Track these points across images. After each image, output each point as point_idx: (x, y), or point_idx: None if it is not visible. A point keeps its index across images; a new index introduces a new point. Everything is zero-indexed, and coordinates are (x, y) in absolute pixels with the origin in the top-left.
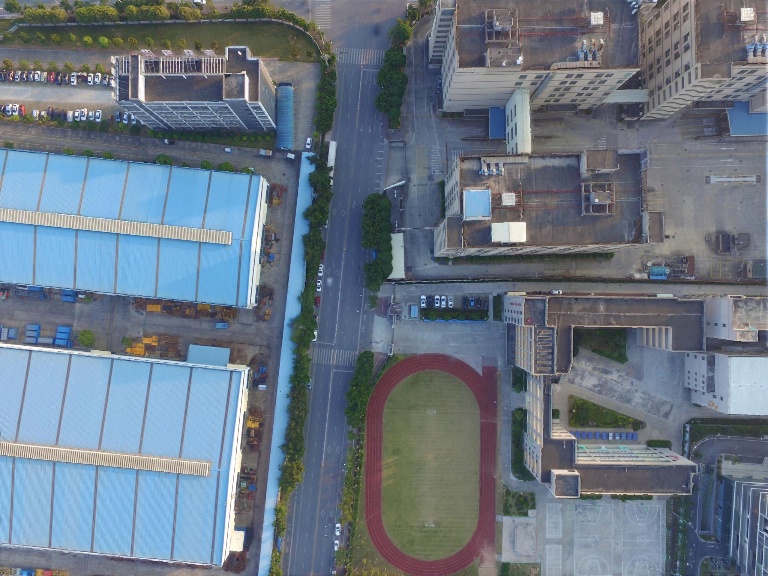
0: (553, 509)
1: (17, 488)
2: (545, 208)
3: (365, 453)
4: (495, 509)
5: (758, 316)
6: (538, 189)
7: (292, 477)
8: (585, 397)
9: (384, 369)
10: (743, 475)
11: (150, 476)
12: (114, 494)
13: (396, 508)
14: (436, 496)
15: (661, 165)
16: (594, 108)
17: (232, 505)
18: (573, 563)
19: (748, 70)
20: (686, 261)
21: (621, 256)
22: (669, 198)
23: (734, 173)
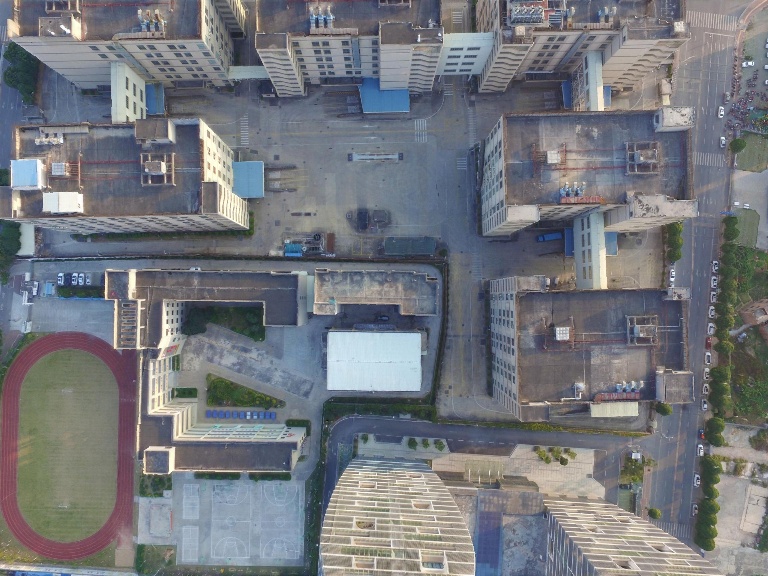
0: (190, 490)
1: None
2: (106, 179)
3: (0, 433)
4: (133, 490)
5: (344, 290)
6: (99, 159)
7: None
8: (224, 376)
9: (21, 347)
10: (380, 455)
11: None
12: None
13: (31, 489)
14: (73, 477)
15: (303, 142)
16: (235, 85)
17: None
18: (210, 545)
19: (318, 42)
20: (319, 238)
21: (262, 233)
22: (311, 175)
23: (376, 151)
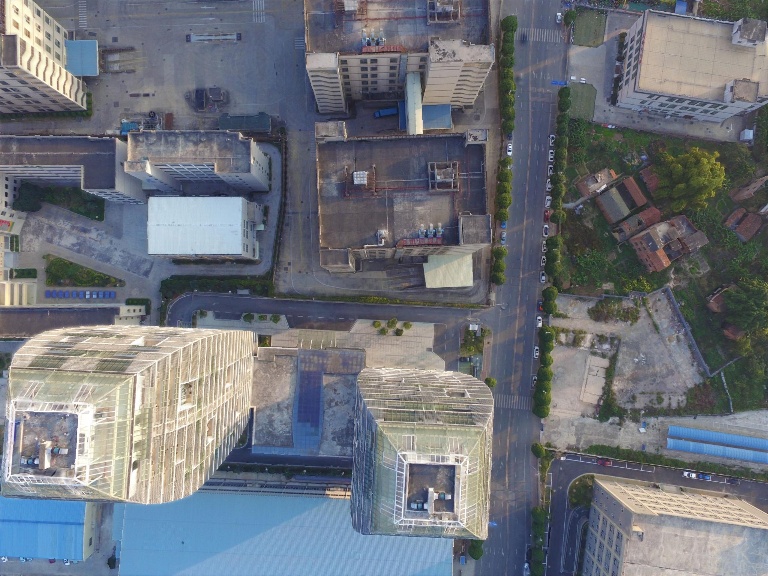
0: None
1: None
2: None
3: None
4: None
5: (159, 150)
6: None
7: None
8: (63, 256)
9: None
10: None
11: None
12: None
13: None
14: None
15: (142, 24)
16: None
17: None
18: None
19: None
20: (153, 115)
21: (101, 115)
22: (150, 57)
23: (214, 31)
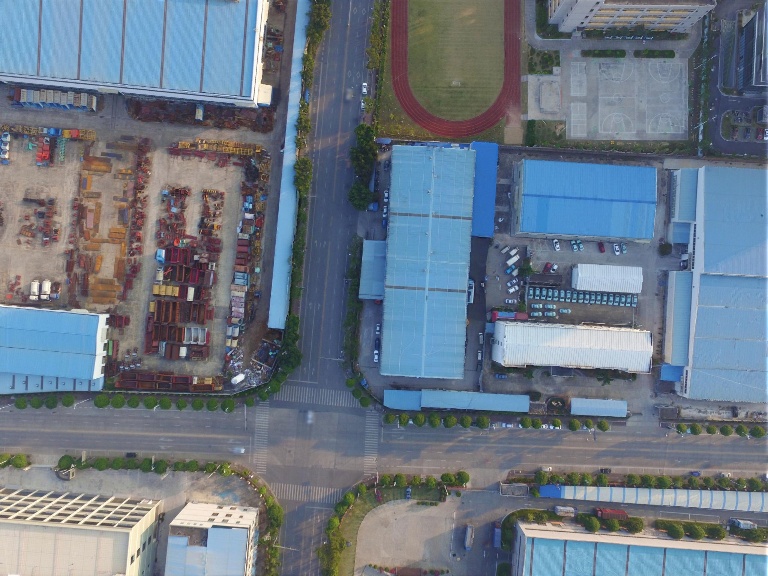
0: (577, 67)
1: (45, 16)
2: None
3: (391, 14)
4: (520, 70)
5: None
6: None
7: (320, 17)
8: None
9: None
10: None
11: (179, 2)
12: (143, 20)
13: (422, 69)
14: (462, 57)
15: None
16: None
17: (260, 51)
18: (598, 120)
19: None
20: None
21: None
22: None
23: None
